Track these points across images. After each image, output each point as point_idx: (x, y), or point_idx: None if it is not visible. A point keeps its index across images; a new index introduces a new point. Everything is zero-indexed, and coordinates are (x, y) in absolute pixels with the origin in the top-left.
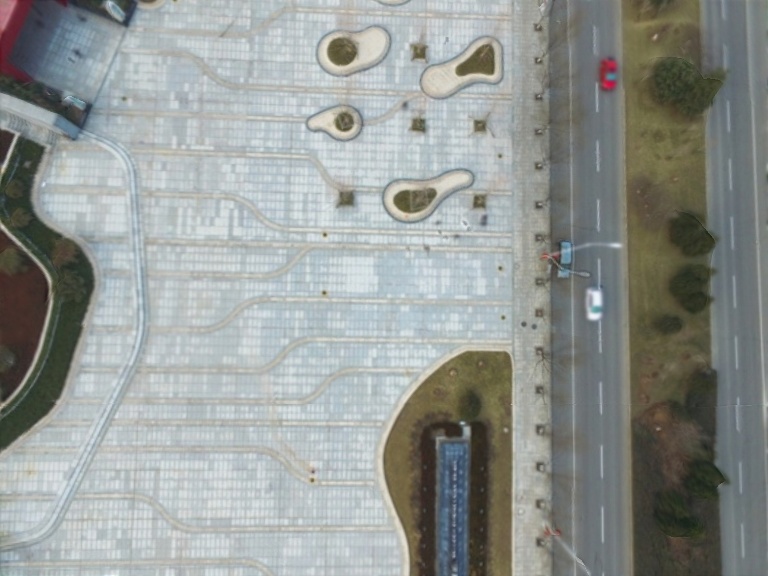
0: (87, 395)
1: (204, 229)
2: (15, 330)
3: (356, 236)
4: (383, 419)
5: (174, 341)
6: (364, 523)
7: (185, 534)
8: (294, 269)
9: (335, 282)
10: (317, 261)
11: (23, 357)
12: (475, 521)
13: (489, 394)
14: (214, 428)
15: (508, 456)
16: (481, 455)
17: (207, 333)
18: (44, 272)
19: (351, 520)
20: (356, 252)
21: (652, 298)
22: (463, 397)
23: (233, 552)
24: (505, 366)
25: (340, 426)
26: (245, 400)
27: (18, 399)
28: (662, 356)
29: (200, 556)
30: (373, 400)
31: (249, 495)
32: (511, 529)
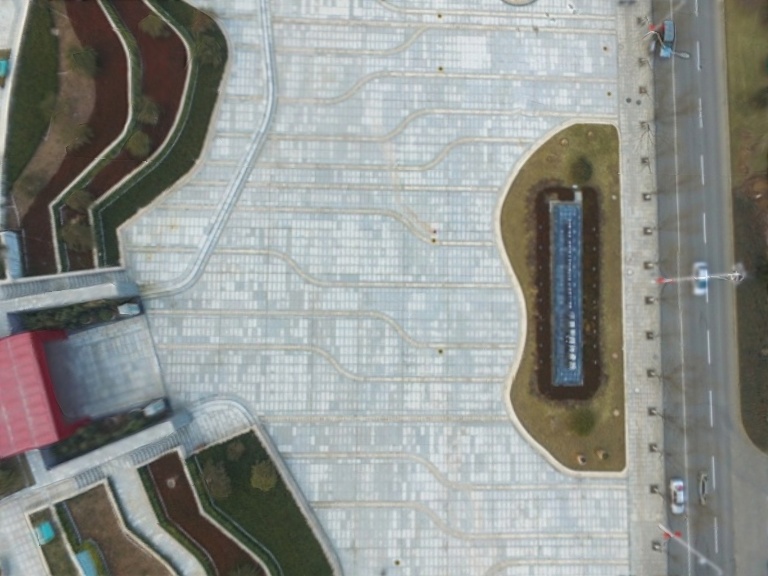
0: (223, 158)
1: (326, 9)
2: (158, 91)
3: (469, 17)
4: (499, 185)
5: (301, 111)
6: (483, 280)
7: (316, 288)
8: (412, 47)
9: (450, 59)
10: (433, 40)
11: (166, 116)
12: (588, 278)
13: (598, 163)
14: (341, 191)
15: (617, 221)
16: (593, 216)
17: (332, 104)
18: (182, 40)
19: (471, 278)
20: (469, 32)
21: (749, 77)
22: (574, 164)
23: (361, 305)
24: (612, 138)
25: (459, 191)
26: (369, 166)
27: (161, 157)
28: (761, 129)
29: (331, 308)
30: (489, 167)
31: (375, 253)
32: (621, 288)
